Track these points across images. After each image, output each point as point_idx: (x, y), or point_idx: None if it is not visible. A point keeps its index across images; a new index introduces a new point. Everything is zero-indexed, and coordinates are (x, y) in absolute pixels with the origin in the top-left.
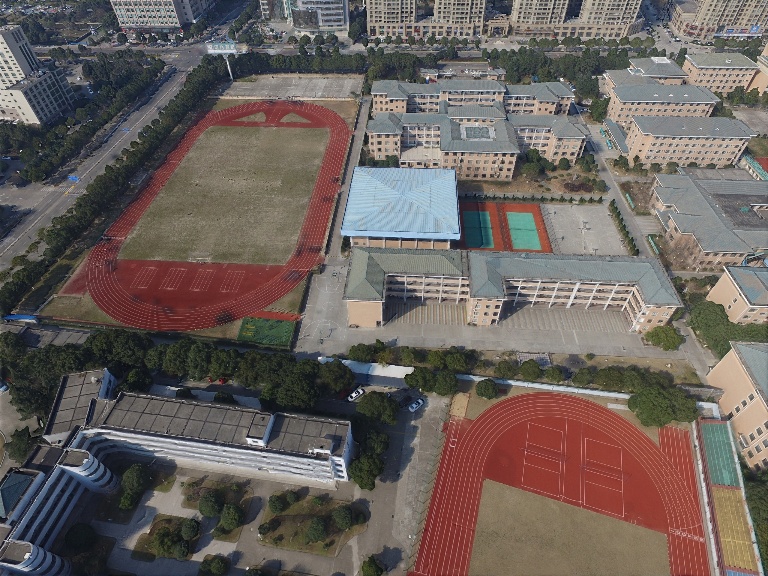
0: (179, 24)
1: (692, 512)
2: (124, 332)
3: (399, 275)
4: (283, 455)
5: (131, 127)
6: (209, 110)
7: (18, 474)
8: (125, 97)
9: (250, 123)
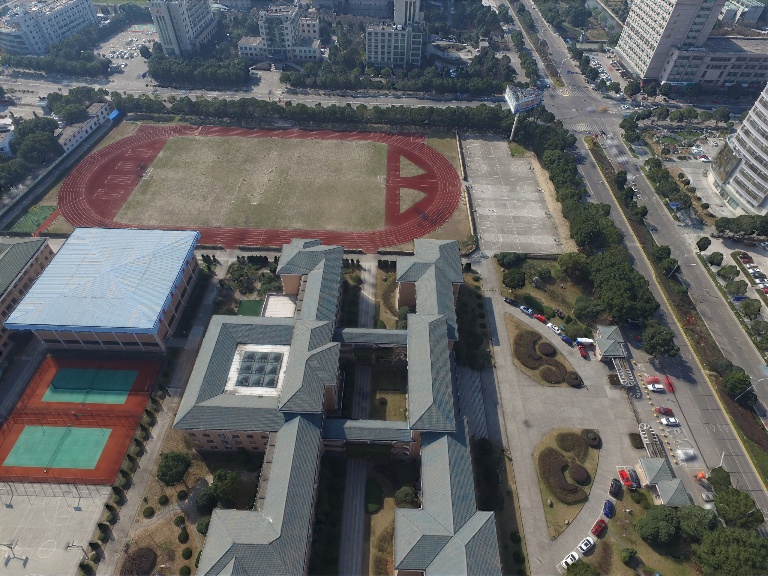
0: (644, 75)
1: None
2: (42, 144)
3: None
4: None
5: (383, 103)
6: (425, 137)
7: None
8: (422, 83)
9: (395, 167)
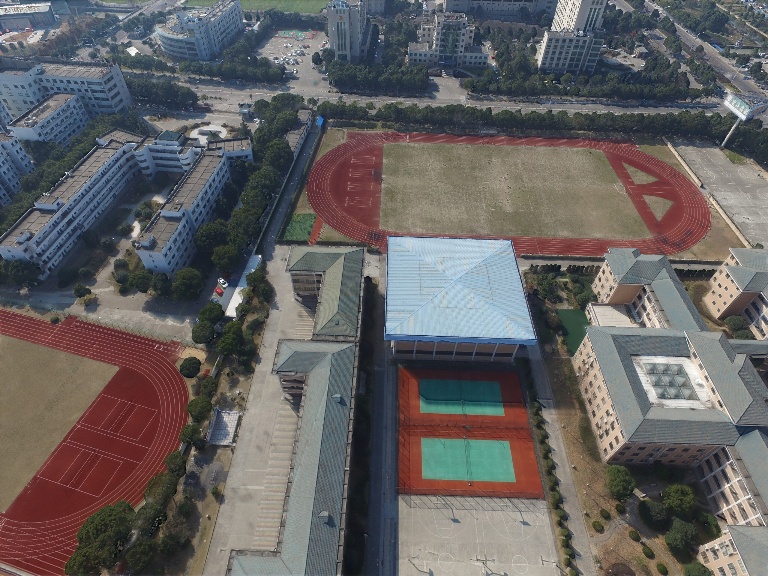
0: None
1: (6, 551)
2: (285, 151)
3: (322, 283)
4: (149, 223)
5: (572, 109)
6: (635, 143)
7: (179, 136)
8: (610, 89)
9: (625, 174)
